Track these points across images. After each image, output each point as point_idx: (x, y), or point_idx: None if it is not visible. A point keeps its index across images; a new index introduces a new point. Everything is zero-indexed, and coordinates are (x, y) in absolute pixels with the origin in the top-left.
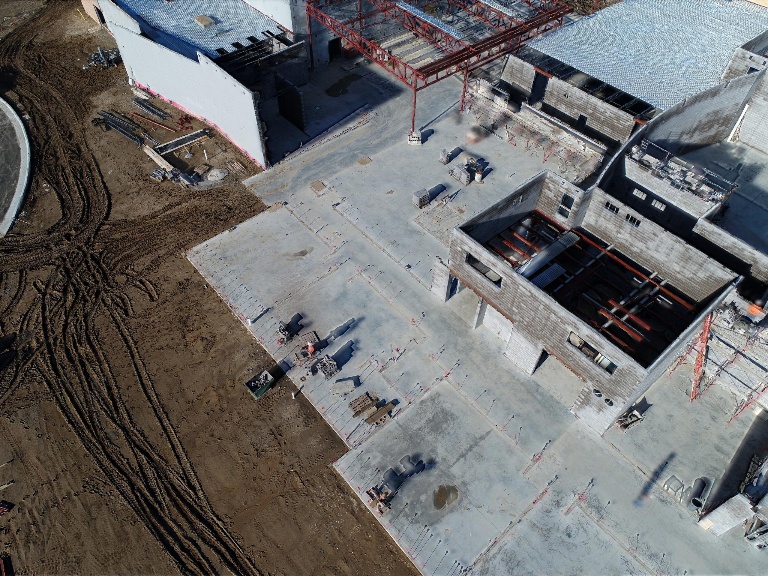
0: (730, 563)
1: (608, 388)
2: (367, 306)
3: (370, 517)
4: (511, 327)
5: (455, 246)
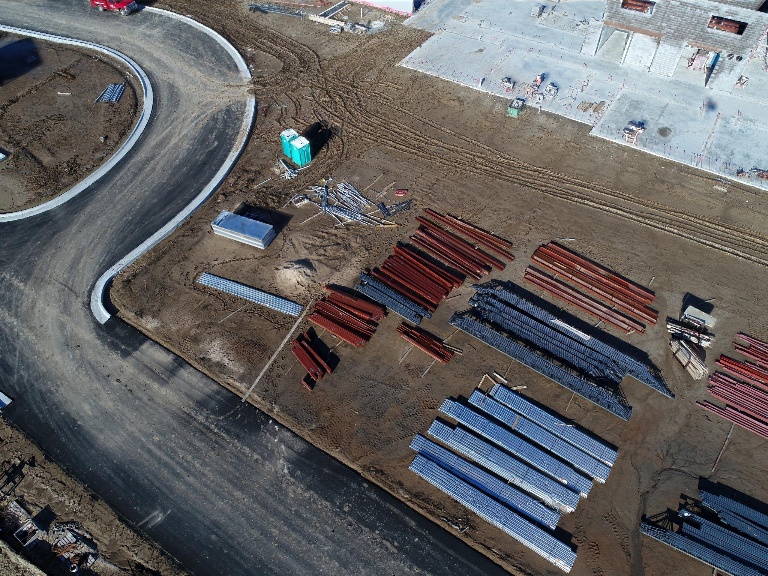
0: None
1: (739, 46)
2: (546, 66)
3: (630, 148)
4: (652, 50)
5: None
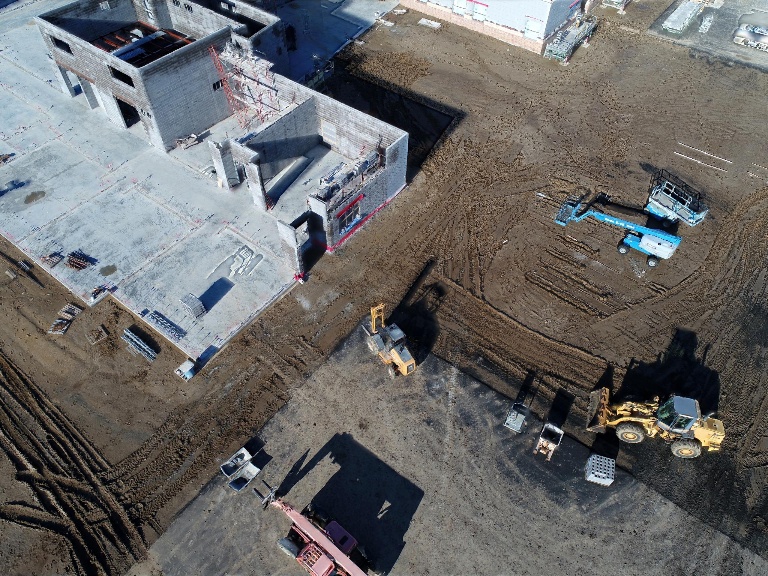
0: (232, 201)
1: (141, 102)
2: (6, 106)
3: None
4: None
5: (43, 34)
